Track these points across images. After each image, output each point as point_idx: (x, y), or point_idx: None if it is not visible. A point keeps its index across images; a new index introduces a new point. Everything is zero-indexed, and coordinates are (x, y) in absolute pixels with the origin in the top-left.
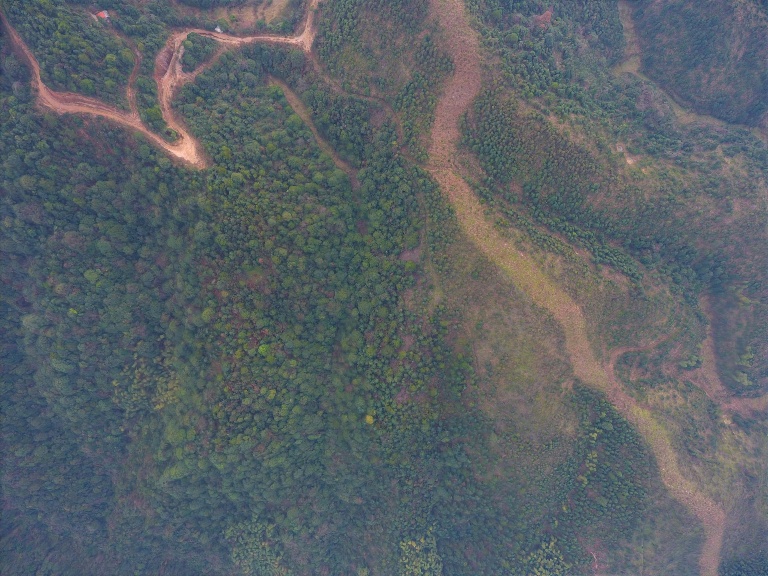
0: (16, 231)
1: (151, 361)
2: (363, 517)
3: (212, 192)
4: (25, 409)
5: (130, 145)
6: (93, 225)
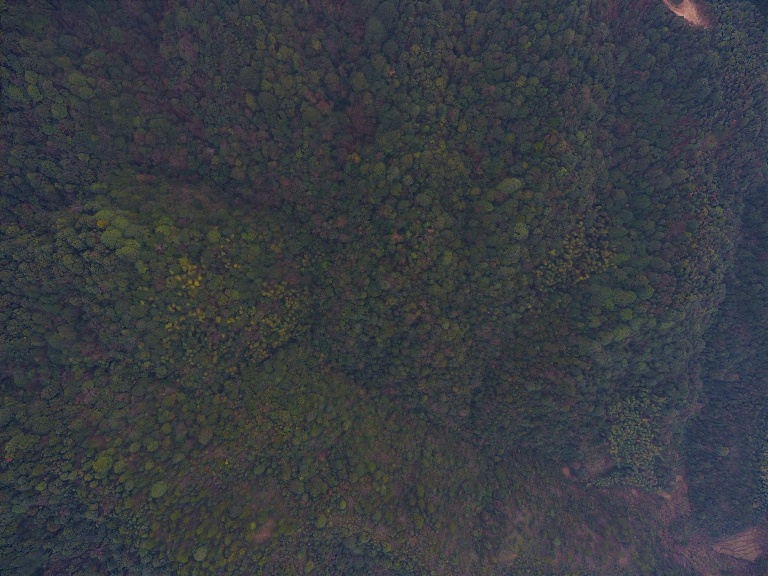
0: (522, 92)
1: (584, 232)
2: (726, 397)
3: (718, 49)
4: (452, 283)
5: (639, 7)
6: (590, 86)
